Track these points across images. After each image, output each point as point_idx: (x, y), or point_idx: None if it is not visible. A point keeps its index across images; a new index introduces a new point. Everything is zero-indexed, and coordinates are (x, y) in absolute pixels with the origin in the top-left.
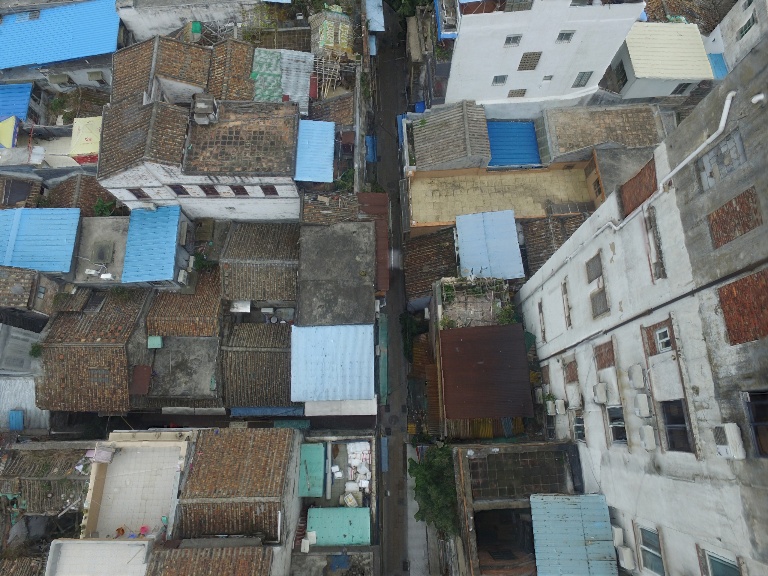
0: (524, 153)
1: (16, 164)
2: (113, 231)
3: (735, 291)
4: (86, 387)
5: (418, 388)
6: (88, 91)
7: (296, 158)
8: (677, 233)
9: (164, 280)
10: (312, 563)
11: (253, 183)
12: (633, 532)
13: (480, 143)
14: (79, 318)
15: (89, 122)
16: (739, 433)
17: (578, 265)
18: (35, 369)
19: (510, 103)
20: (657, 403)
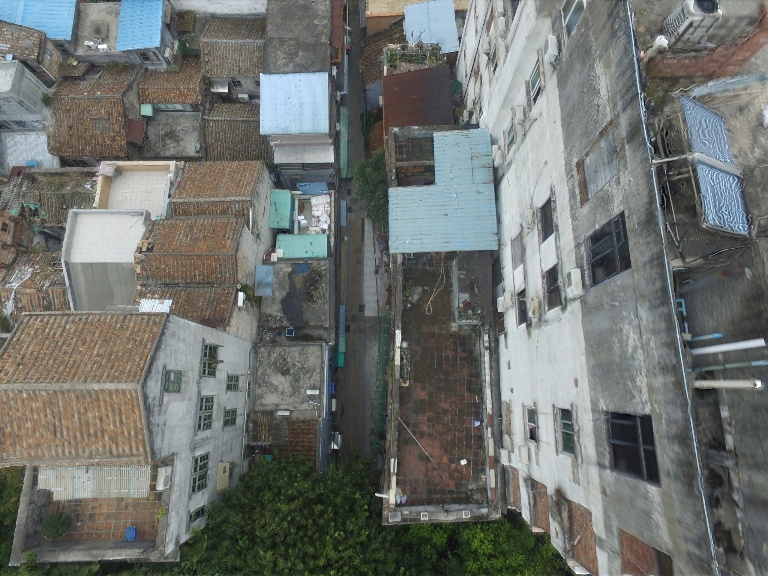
0: None
1: None
2: (107, 14)
3: None
4: (90, 135)
5: None
6: None
7: None
8: None
9: (152, 51)
10: (280, 269)
11: None
12: (503, 139)
13: None
14: (81, 83)
15: None
16: None
17: None
18: (46, 117)
19: None
20: (509, 1)
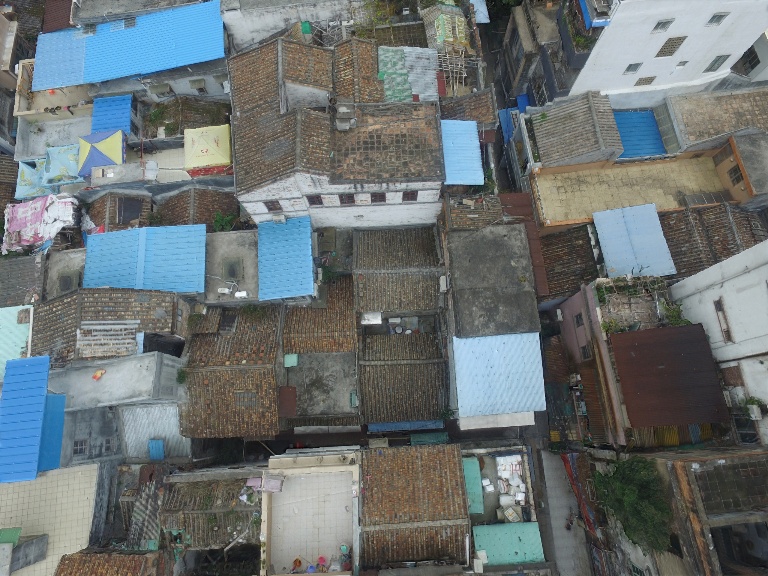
0: (648, 143)
1: (131, 181)
2: (239, 246)
3: None
4: (232, 412)
5: (557, 393)
6: (187, 100)
7: (444, 161)
8: None
9: None
10: None
11: (398, 189)
12: None
13: (611, 135)
14: (215, 340)
15: (203, 133)
16: None
17: None
18: (180, 396)
19: (636, 92)
20: None
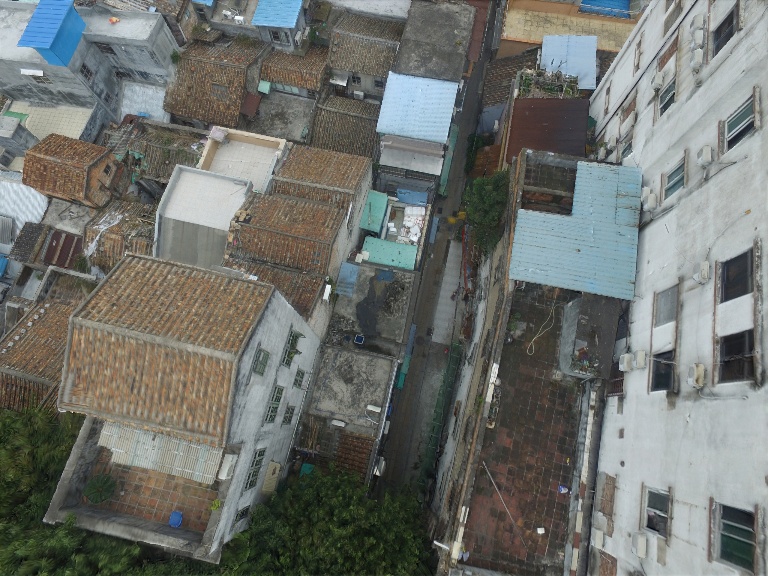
0: (616, 5)
1: None
2: None
3: None
4: (206, 99)
5: None
6: None
7: None
8: None
9: (285, 31)
10: (362, 272)
11: None
12: (660, 182)
13: None
14: (210, 48)
15: None
16: None
17: (658, 9)
18: (170, 73)
19: None
20: (711, 33)
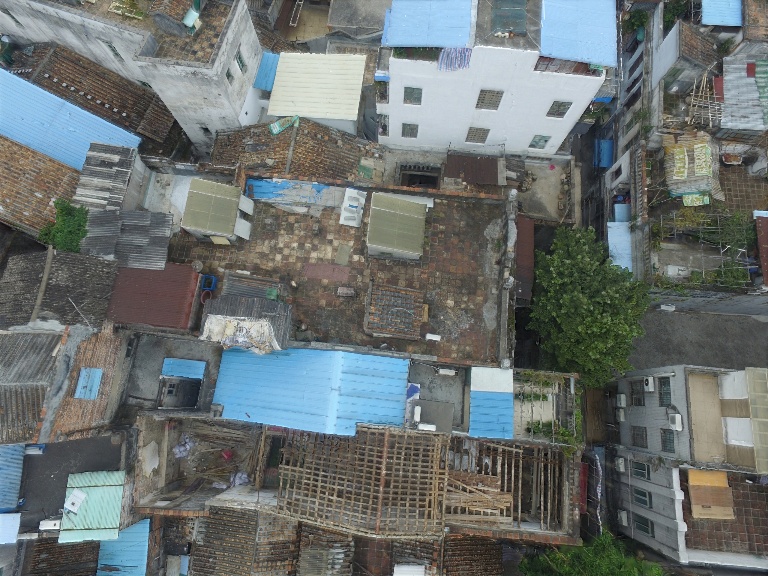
0: None
1: None
2: None
3: None
4: None
5: None
6: None
7: None
8: None
9: None
10: None
11: None
12: None
13: None
14: None
15: None
16: None
17: None
18: None
19: None
20: None
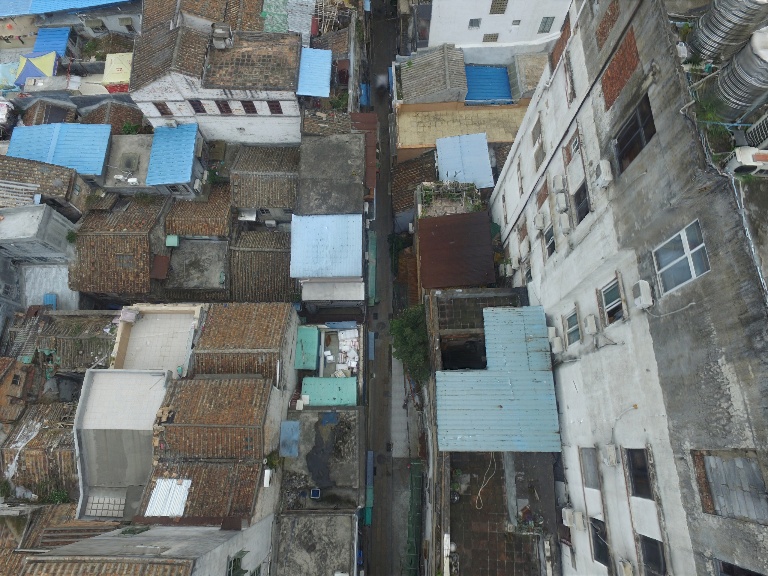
0: (498, 92)
1: (56, 89)
2: (138, 146)
3: (609, 73)
4: (113, 271)
5: (402, 291)
6: (118, 36)
7: (298, 77)
8: (581, 59)
9: (182, 185)
10: (305, 419)
11: (261, 98)
12: (562, 324)
13: (458, 79)
14: (108, 216)
15: (120, 56)
16: (609, 165)
17: (527, 138)
18: (70, 253)
19: (485, 47)
20: (571, 197)
